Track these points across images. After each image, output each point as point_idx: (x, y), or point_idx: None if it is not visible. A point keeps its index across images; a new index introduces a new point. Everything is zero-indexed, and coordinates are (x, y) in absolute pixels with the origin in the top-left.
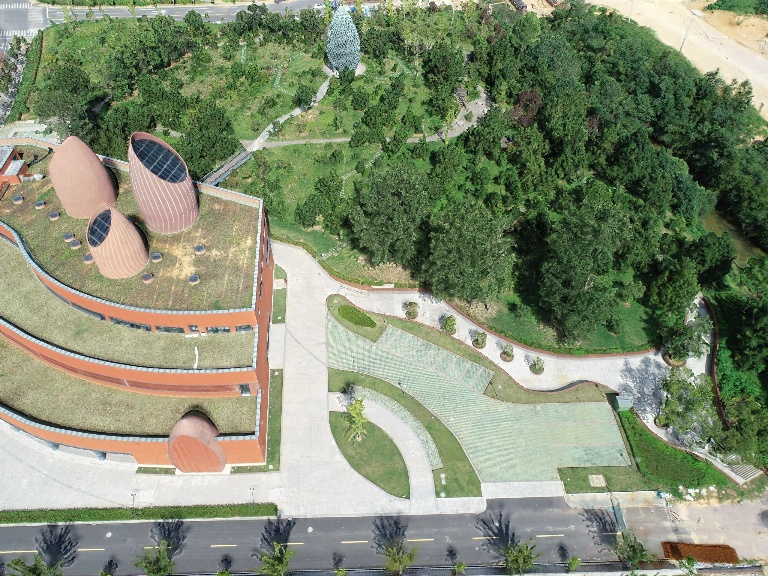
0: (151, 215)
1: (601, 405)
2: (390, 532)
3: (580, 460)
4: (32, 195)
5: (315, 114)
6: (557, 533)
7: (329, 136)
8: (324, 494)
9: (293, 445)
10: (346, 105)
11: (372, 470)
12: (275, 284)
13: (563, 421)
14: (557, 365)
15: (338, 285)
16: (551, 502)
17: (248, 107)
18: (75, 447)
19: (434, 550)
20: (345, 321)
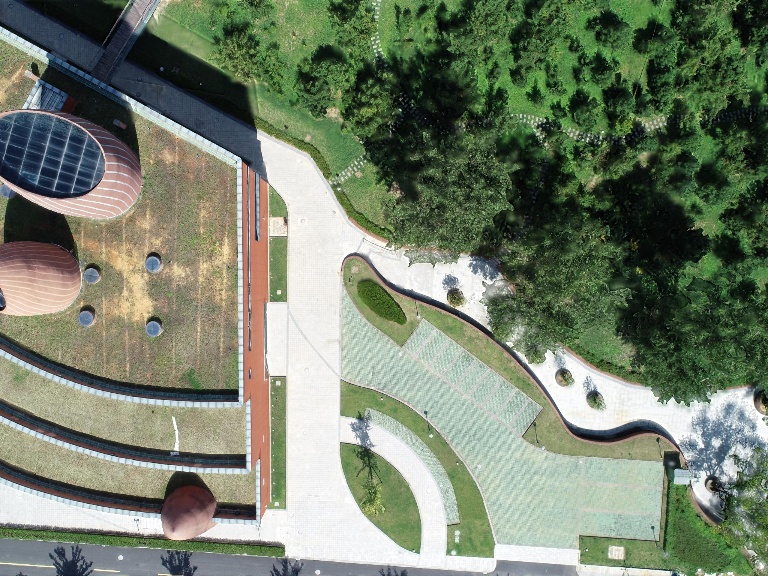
0: None
1: (654, 465)
2: None
3: (606, 529)
4: None
5: None
6: None
7: None
8: (332, 539)
9: (300, 480)
10: None
11: (384, 520)
12: (271, 226)
13: (603, 481)
14: (621, 395)
15: (359, 236)
16: (562, 570)
17: None
18: None
19: None
20: (366, 308)
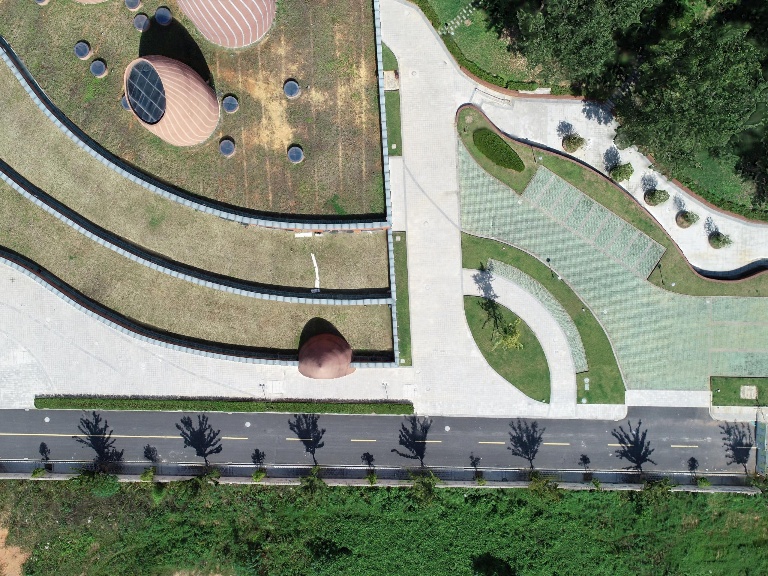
0: (208, 31)
1: None
2: (527, 435)
3: (737, 369)
4: None
5: None
6: (692, 444)
7: None
8: (460, 393)
9: (425, 336)
10: None
11: (512, 371)
12: None
13: (732, 320)
14: (743, 235)
15: (471, 86)
16: (694, 413)
17: None
18: None
19: (569, 454)
20: (482, 157)
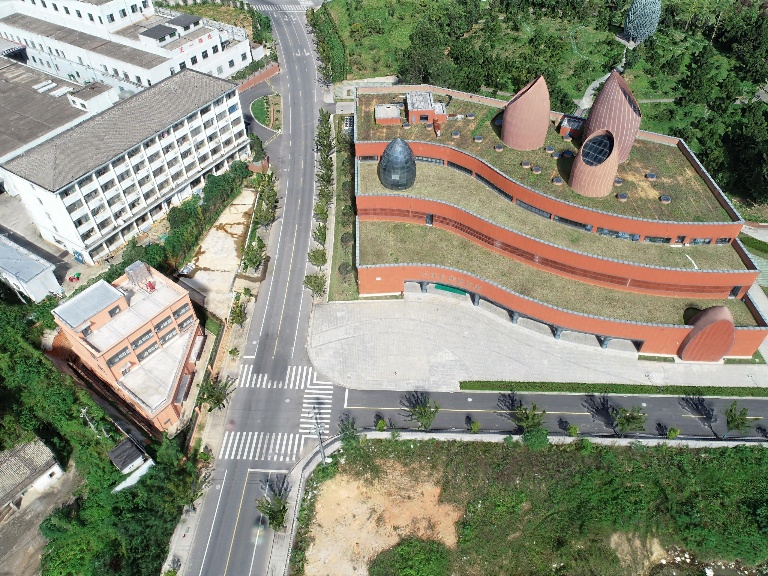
0: None
1: None
2: None
3: None
4: (464, 131)
5: (630, 78)
6: None
7: (651, 97)
8: None
9: (766, 345)
10: (660, 70)
11: None
12: None
13: None
14: None
15: None
16: None
17: (562, 71)
18: (592, 334)
19: None
20: (753, 250)
